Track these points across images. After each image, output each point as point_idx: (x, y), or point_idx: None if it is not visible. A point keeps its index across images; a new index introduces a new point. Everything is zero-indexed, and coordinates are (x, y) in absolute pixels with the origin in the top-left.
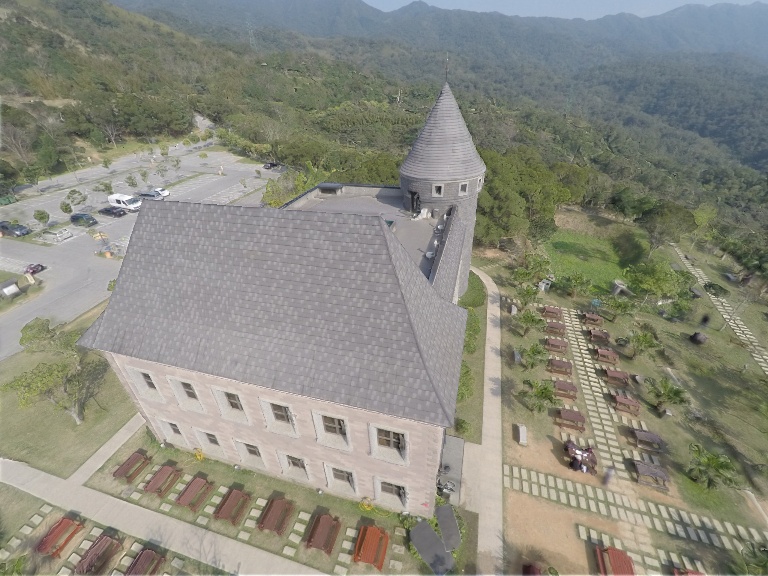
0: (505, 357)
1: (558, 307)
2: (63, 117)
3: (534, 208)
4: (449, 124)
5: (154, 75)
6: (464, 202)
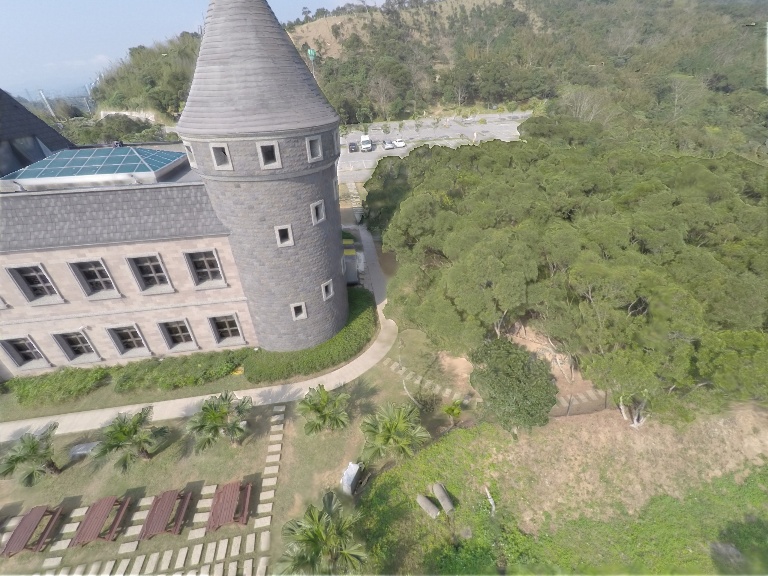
0: (100, 435)
1: (269, 523)
2: (440, 79)
3: (581, 336)
4: None
5: (574, 45)
6: (211, 183)
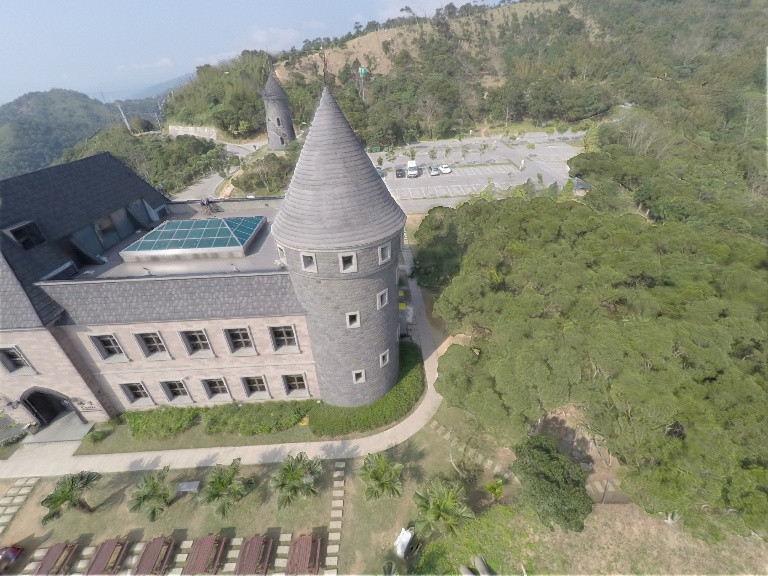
0: (196, 474)
1: (335, 575)
2: (488, 95)
3: (619, 445)
4: (302, 156)
5: (633, 55)
6: (296, 275)
